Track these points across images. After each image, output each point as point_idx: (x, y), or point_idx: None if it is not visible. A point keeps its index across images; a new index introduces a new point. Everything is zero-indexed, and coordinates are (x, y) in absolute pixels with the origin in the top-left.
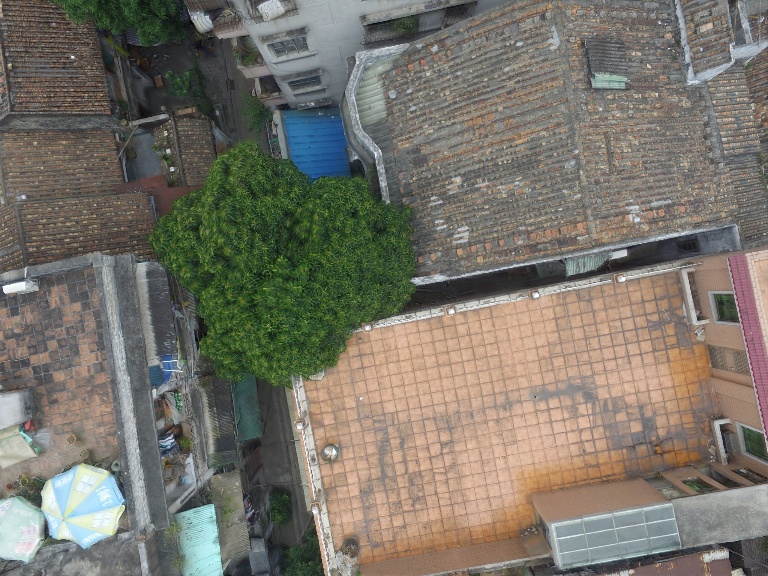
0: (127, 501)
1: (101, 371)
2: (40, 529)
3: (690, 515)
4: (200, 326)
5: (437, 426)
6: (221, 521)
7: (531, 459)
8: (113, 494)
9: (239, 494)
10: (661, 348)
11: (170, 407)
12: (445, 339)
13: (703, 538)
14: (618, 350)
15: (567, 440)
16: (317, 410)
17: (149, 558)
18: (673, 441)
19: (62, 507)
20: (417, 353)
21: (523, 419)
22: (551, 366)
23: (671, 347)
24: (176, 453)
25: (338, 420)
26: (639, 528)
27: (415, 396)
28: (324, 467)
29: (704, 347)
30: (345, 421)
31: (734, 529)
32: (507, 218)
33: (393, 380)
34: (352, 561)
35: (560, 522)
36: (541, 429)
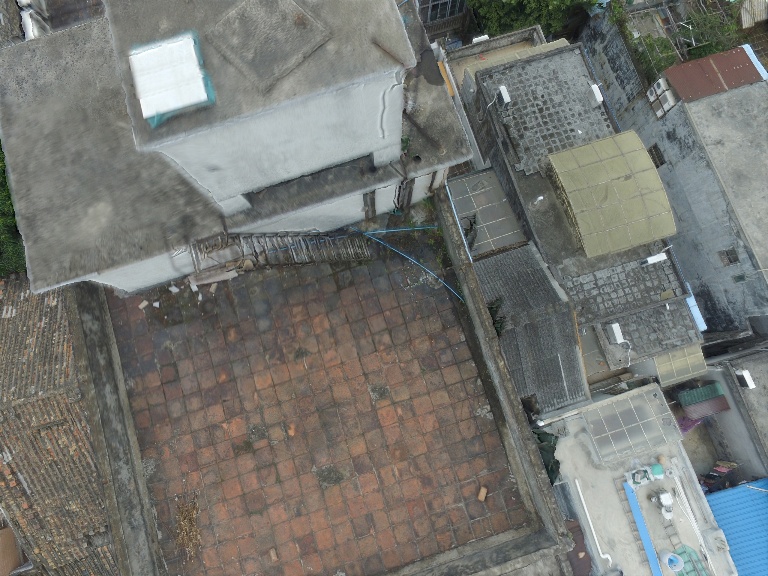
0: None
1: None
2: None
3: None
4: None
5: None
6: None
7: None
8: None
9: None
10: None
11: None
12: None
13: None
14: None
15: None
16: None
17: None
18: None
19: None
20: None
21: None
22: None
23: None
24: None
25: None
26: None
27: None
28: None
29: None
30: None
31: None
32: (8, 346)
33: None
34: None
35: None
36: None
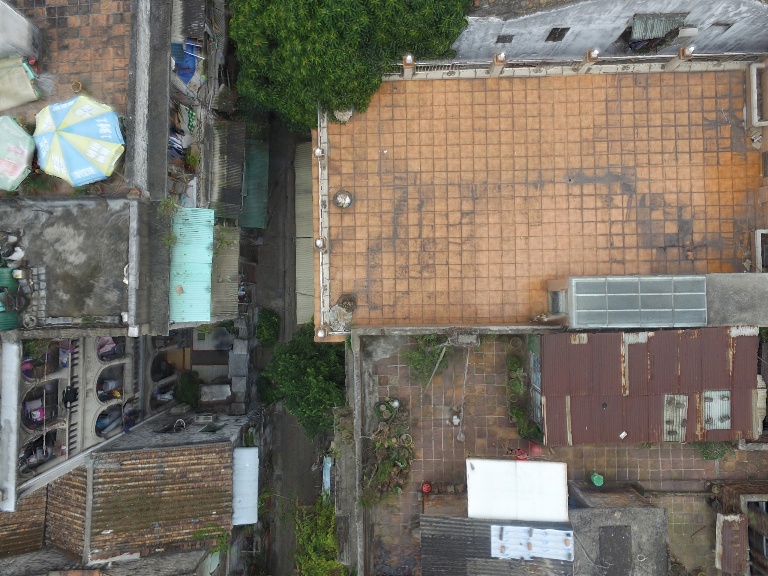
0: (127, 146)
1: (120, 23)
2: (28, 155)
3: (722, 292)
4: (226, 61)
5: (461, 193)
6: (215, 253)
7: (554, 244)
8: (114, 132)
9: (235, 253)
10: (712, 149)
11: (182, 125)
12: (485, 104)
13: (732, 318)
14: (666, 144)
15: (595, 230)
16: (337, 156)
17: (139, 220)
18: (707, 249)
19: (57, 123)
20: (453, 114)
21: (553, 201)
22: (592, 150)
23: (723, 150)
24: (180, 170)
25: (357, 170)
26: (665, 297)
27: (443, 158)
28: (334, 217)
29: (758, 155)
30: (364, 172)
31: (766, 313)
32: None
33: (423, 138)
34: (346, 318)
35: (582, 278)
36: (570, 214)
